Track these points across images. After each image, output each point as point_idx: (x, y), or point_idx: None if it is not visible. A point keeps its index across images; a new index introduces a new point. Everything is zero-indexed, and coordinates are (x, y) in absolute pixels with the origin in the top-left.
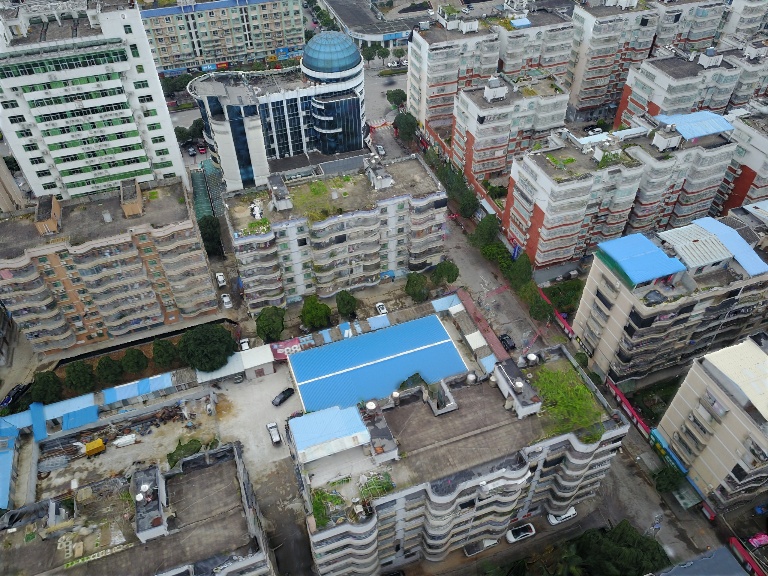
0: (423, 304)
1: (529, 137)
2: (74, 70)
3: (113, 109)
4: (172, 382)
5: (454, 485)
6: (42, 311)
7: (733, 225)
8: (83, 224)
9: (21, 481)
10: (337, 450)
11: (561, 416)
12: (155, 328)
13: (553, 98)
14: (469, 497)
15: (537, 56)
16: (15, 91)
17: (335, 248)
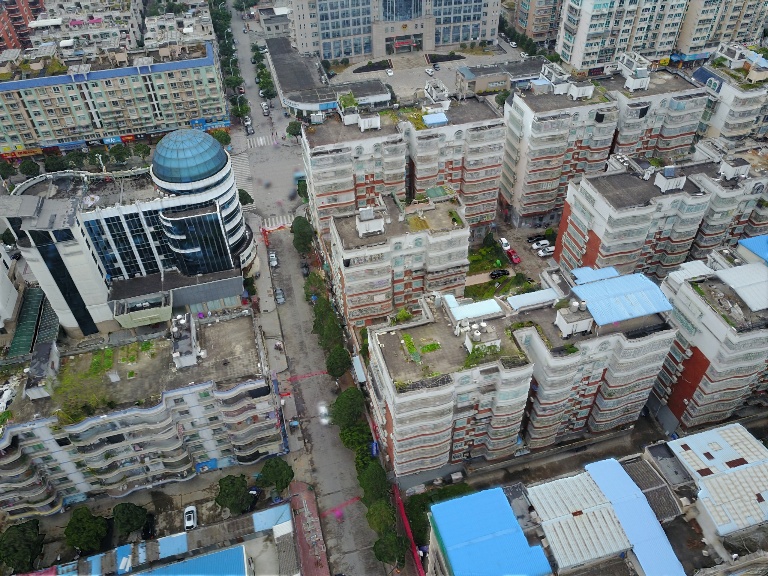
0: (240, 518)
1: (422, 276)
2: None
3: None
4: None
5: None
6: None
7: (644, 480)
8: None
9: None
10: None
11: None
12: None
13: (445, 235)
14: None
15: (459, 158)
16: None
17: (111, 448)
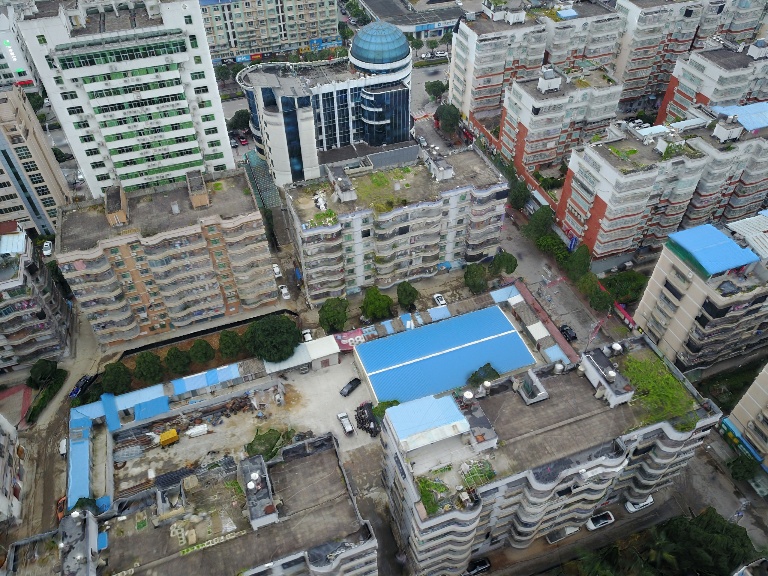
0: (482, 295)
1: (580, 128)
2: (134, 61)
3: (170, 100)
4: (239, 373)
5: (554, 473)
6: (111, 302)
7: None
8: (151, 215)
9: (98, 471)
10: (438, 439)
11: (655, 405)
12: (215, 319)
13: (607, 89)
14: (566, 485)
15: (582, 47)
16: (75, 82)
17: (398, 239)
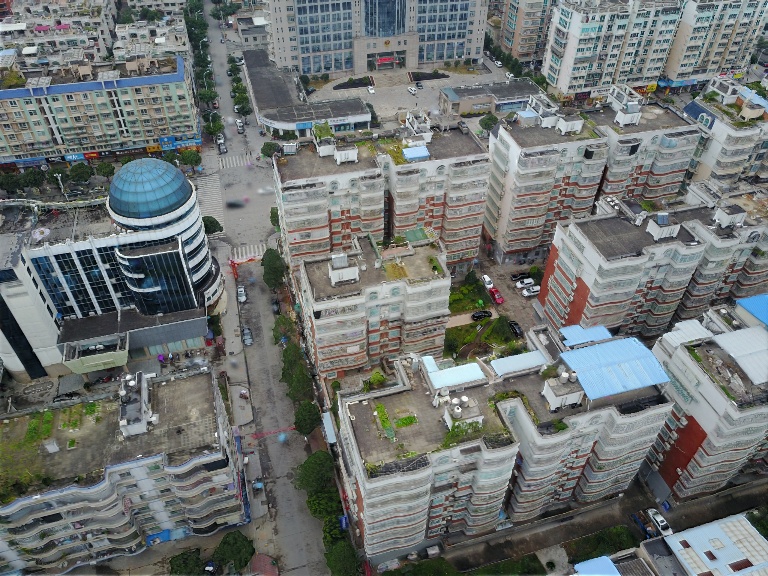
0: None
1: (399, 326)
2: None
3: None
4: None
5: None
6: None
7: None
8: None
9: None
10: None
11: None
12: None
13: (425, 285)
14: None
15: (441, 194)
16: None
17: (47, 528)
